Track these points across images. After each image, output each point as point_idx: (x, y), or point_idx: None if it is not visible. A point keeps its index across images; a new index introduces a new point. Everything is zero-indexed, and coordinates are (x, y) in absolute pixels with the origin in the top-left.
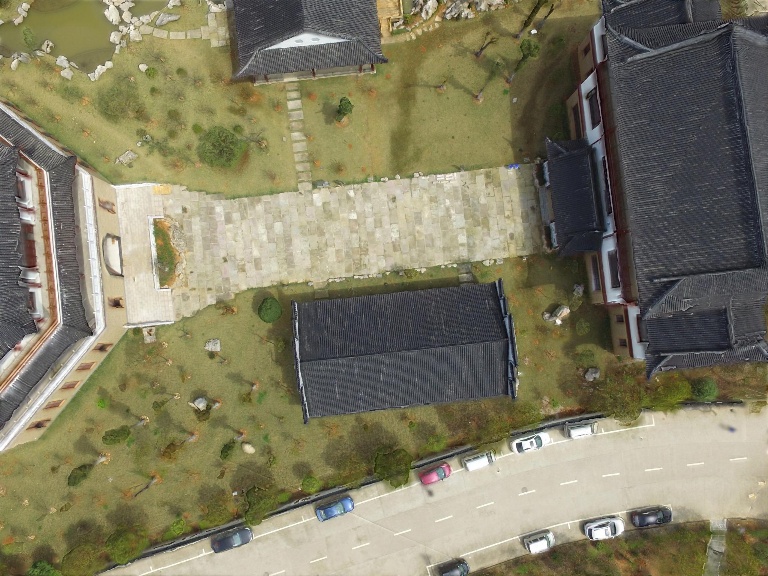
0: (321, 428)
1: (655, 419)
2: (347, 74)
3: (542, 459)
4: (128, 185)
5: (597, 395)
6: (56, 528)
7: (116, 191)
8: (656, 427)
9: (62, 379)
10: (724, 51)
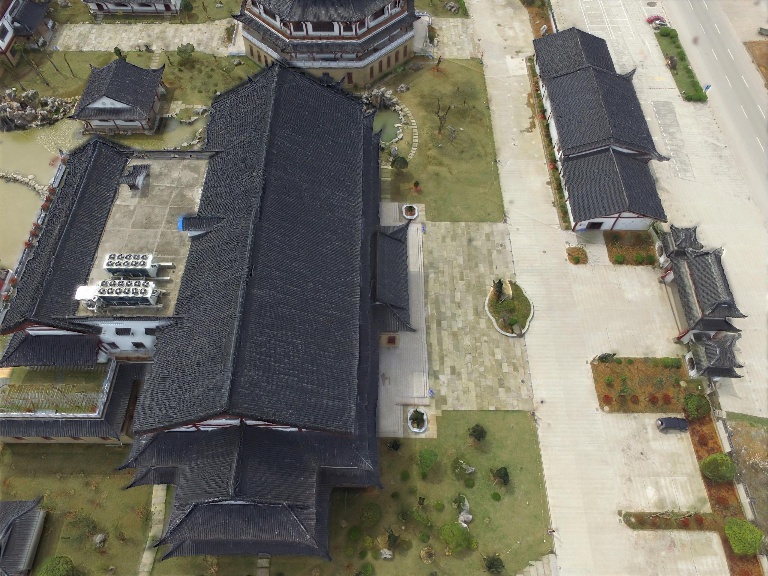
0: None
1: None
2: None
3: None
4: None
5: None
6: None
7: None
8: None
9: None
10: None
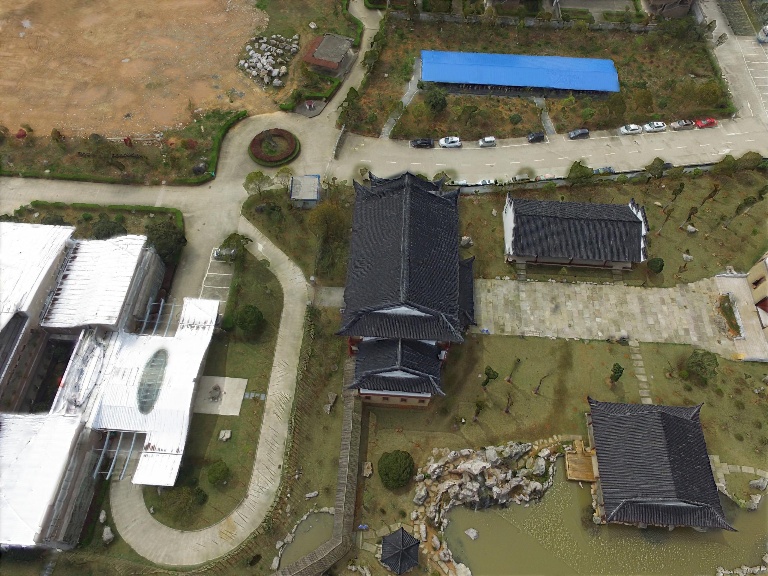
0: None
1: None
2: None
3: (480, 177)
4: (765, 359)
5: None
6: None
7: None
8: None
9: None
10: None
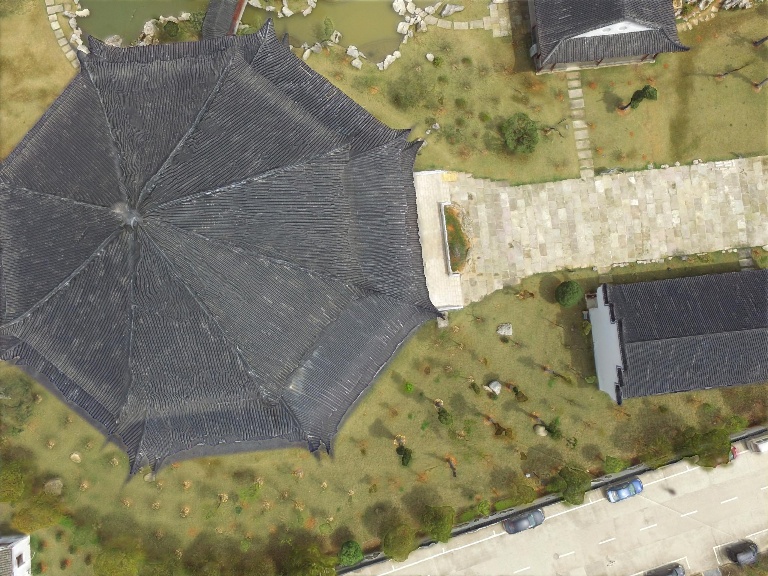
0: (609, 411)
1: None
2: (628, 63)
3: None
4: (421, 172)
5: None
6: (354, 510)
7: None
8: None
9: None
10: None
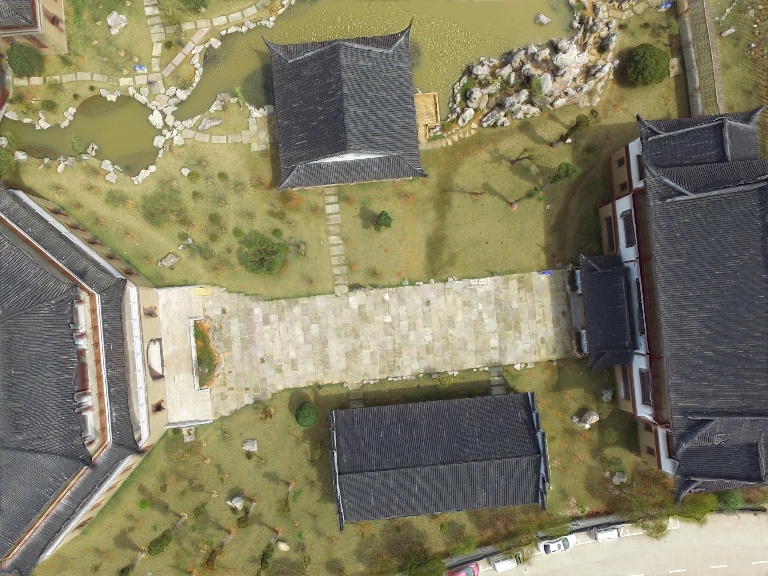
0: (354, 526)
1: (680, 522)
2: (384, 180)
3: (569, 559)
4: (170, 288)
5: (624, 498)
6: None
7: (158, 293)
8: (681, 530)
9: (108, 486)
10: (763, 204)
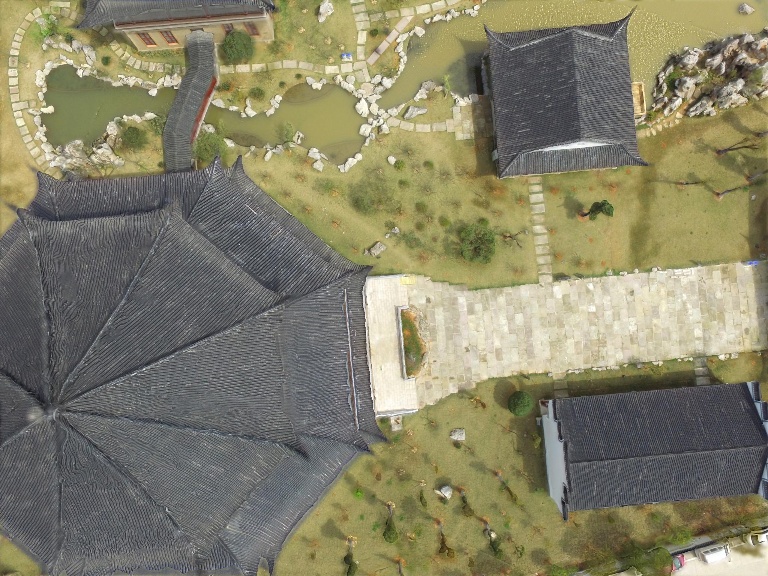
0: (560, 516)
1: None
2: (589, 169)
3: None
4: (379, 277)
5: None
6: None
7: None
8: None
9: None
10: None
